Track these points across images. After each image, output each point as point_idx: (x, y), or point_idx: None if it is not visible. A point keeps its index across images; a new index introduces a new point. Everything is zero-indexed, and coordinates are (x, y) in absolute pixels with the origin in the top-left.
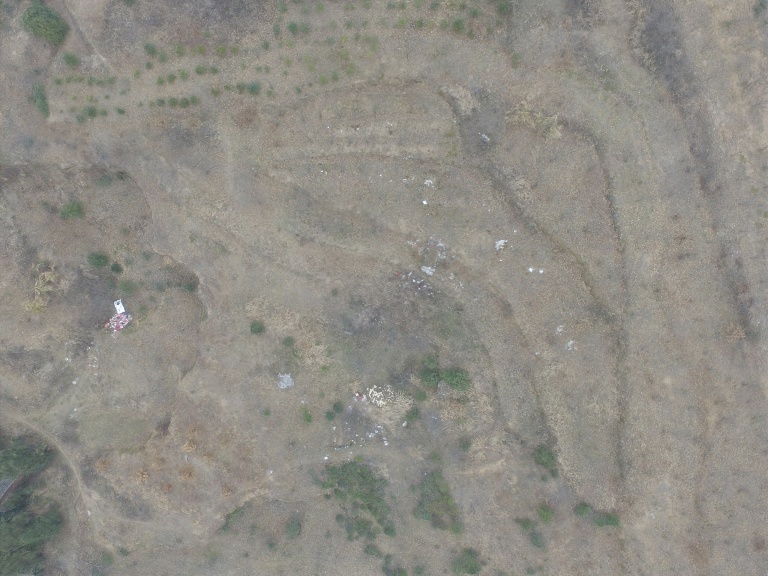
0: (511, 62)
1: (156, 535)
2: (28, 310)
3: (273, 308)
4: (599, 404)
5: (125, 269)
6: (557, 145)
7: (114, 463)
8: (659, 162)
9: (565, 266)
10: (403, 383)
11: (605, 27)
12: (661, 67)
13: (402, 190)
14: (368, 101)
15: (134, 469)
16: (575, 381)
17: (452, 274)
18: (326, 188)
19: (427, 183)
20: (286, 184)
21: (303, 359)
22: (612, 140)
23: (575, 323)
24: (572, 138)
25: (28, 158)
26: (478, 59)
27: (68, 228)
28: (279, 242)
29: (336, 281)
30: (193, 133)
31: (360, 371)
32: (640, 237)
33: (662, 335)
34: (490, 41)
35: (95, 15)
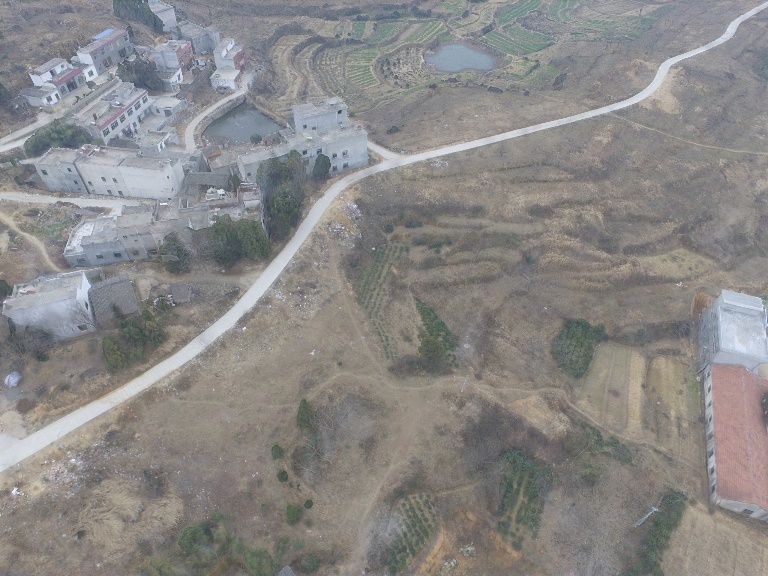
0: None
1: (95, 0)
2: None
3: None
4: None
5: None
6: None
7: (93, 8)
8: None
9: None
10: None
11: None
12: None
13: None
14: None
15: (88, 6)
16: None
17: None
18: None
19: None
20: None
21: None
22: None
23: None
24: None
25: None
26: None
27: None
28: None
29: None
30: None
31: None
32: None
33: None
34: None
35: None
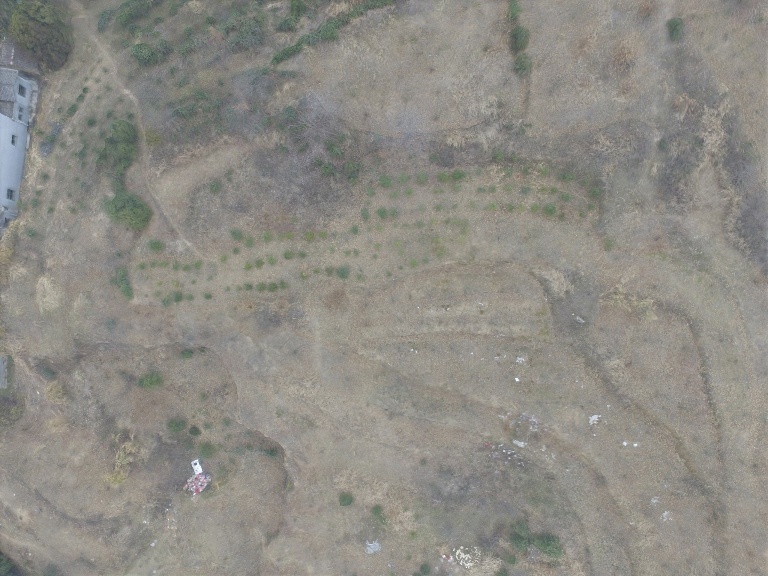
0: (604, 244)
1: None
2: (109, 482)
3: (361, 479)
4: (696, 575)
5: (203, 432)
6: (651, 325)
7: None
8: (754, 341)
9: (659, 439)
10: (492, 547)
11: (699, 211)
12: (756, 250)
13: (494, 368)
14: (458, 281)
15: None
16: (671, 551)
17: (544, 446)
18: (417, 367)
19: (519, 361)
20: (375, 361)
21: (390, 525)
22: (707, 320)
23: (670, 494)
24: (666, 318)
25: (111, 339)
26: (570, 241)
27: (146, 396)
28: (368, 417)
29: (425, 452)
30: (281, 315)
31: (447, 535)
32: (737, 414)
33: (759, 508)
34: (582, 223)
35: (181, 203)
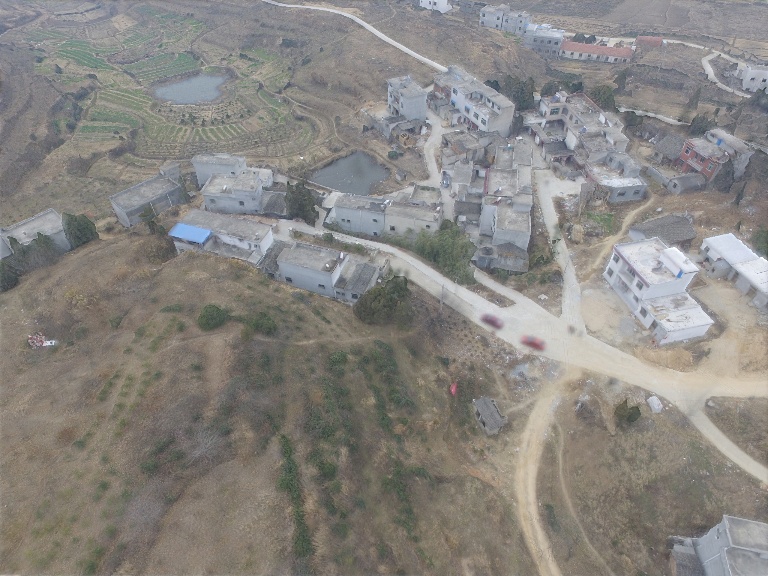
0: None
1: None
2: None
3: None
4: None
5: (65, 349)
6: None
7: None
8: None
9: None
10: None
11: None
12: None
13: None
14: None
15: None
16: None
17: None
18: None
19: None
20: None
21: None
22: None
23: None
24: None
25: None
26: None
27: None
28: None
29: None
30: None
31: None
32: None
33: None
34: None
35: (197, 346)
